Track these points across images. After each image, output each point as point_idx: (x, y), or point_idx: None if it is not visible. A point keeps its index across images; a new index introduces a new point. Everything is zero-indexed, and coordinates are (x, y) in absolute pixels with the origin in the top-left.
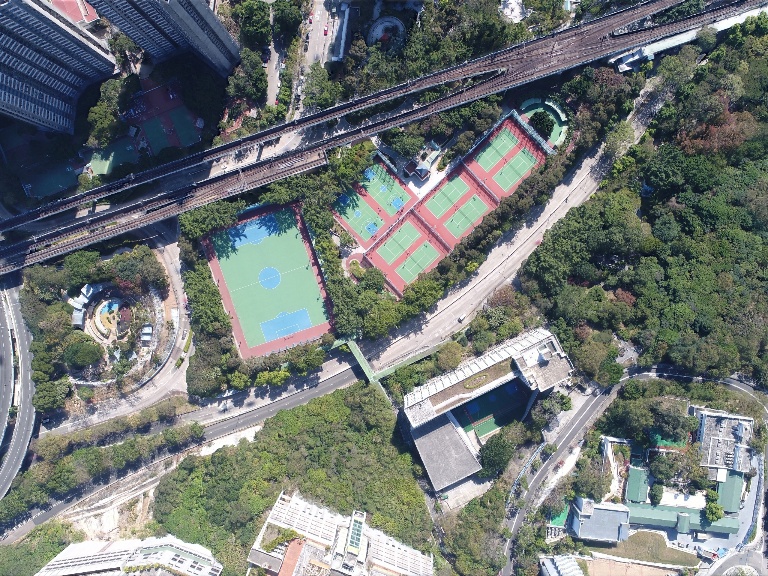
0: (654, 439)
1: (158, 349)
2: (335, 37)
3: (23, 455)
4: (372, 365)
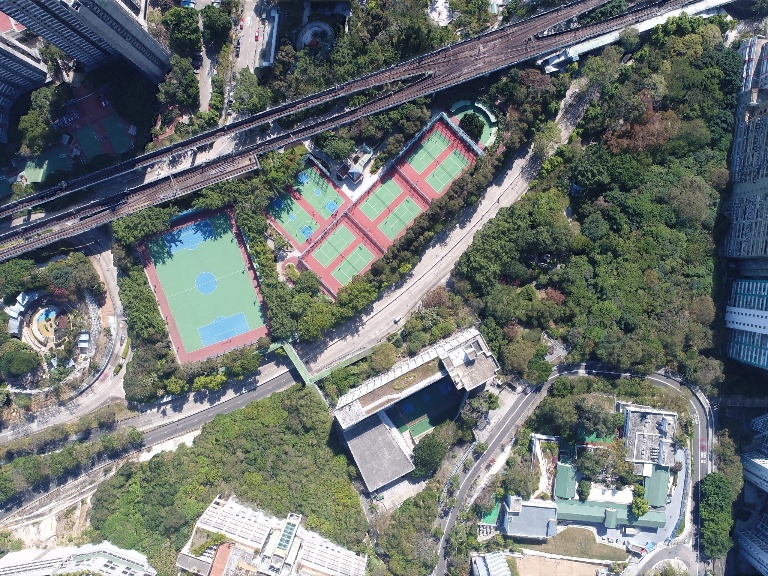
0: (582, 436)
1: (96, 356)
2: (266, 43)
3: None
4: (310, 368)
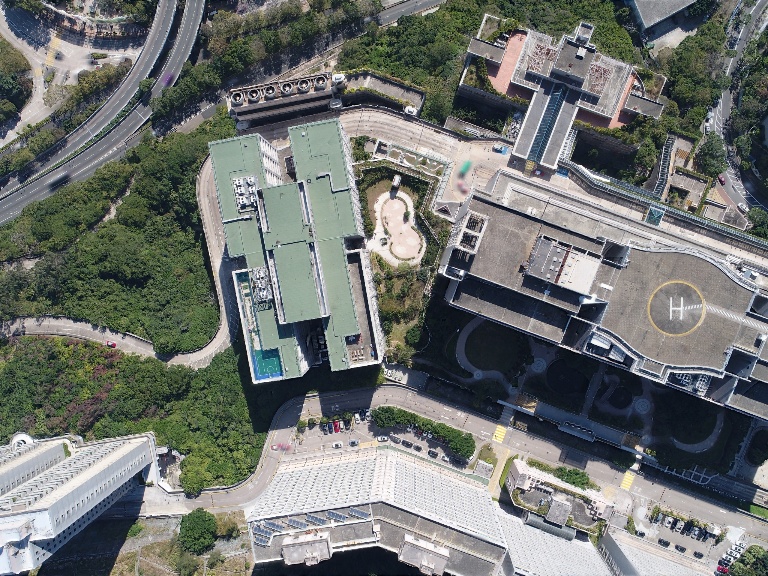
0: None
1: None
2: None
3: (192, 42)
4: None
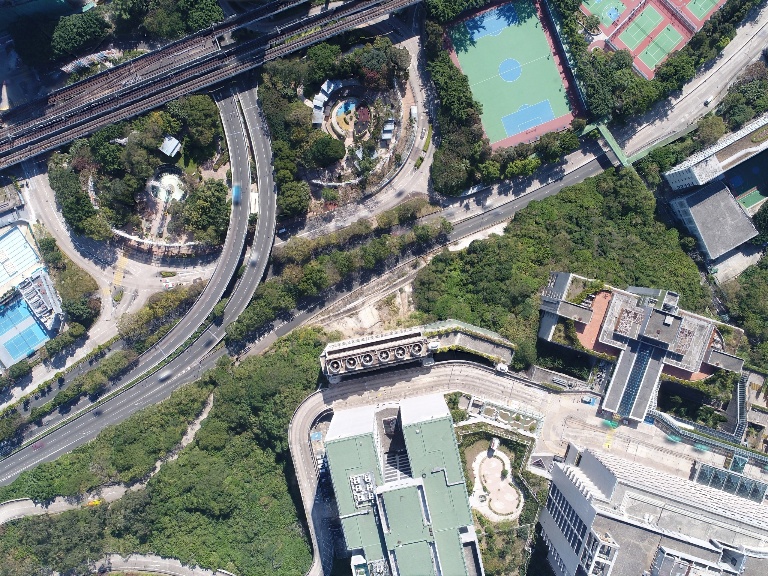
0: None
1: (396, 150)
2: None
3: (264, 264)
4: None
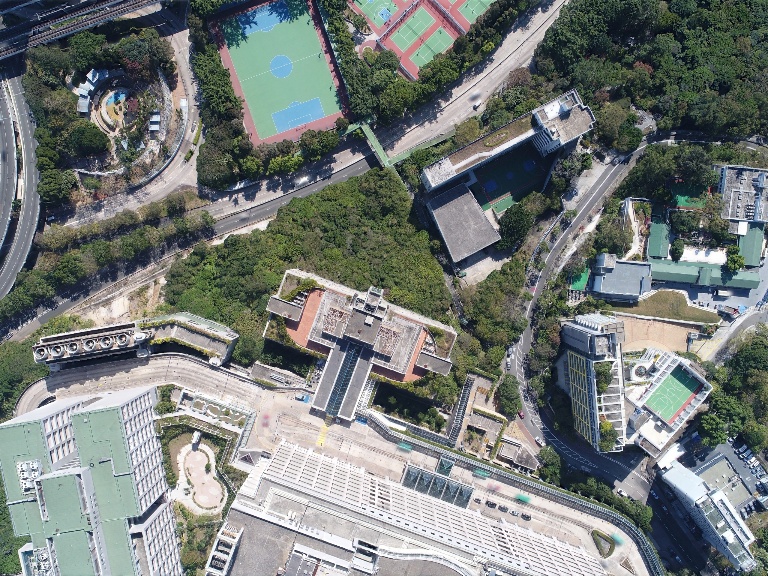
0: (674, 199)
1: (166, 142)
2: None
3: (27, 250)
4: None
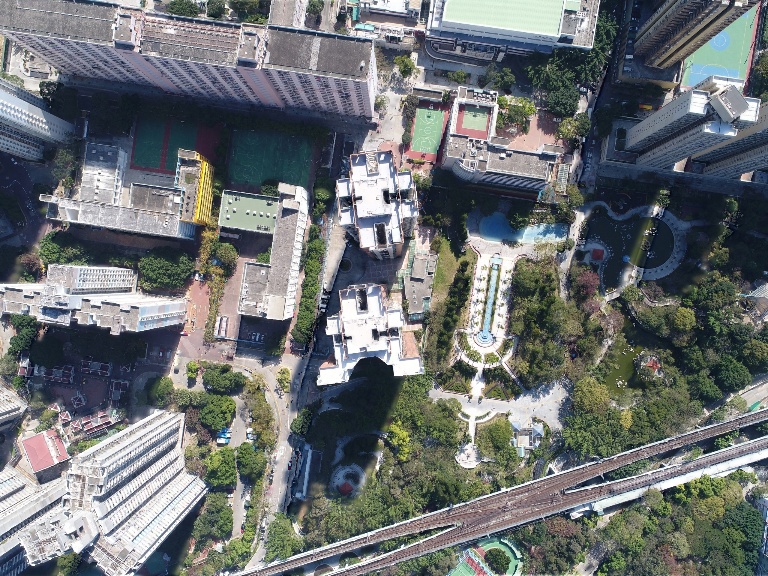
0: None
1: None
2: (299, 472)
3: None
4: None
